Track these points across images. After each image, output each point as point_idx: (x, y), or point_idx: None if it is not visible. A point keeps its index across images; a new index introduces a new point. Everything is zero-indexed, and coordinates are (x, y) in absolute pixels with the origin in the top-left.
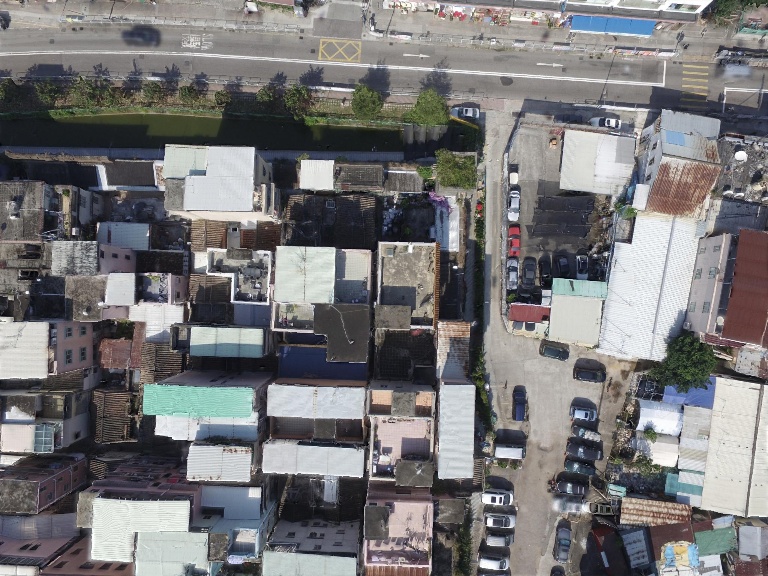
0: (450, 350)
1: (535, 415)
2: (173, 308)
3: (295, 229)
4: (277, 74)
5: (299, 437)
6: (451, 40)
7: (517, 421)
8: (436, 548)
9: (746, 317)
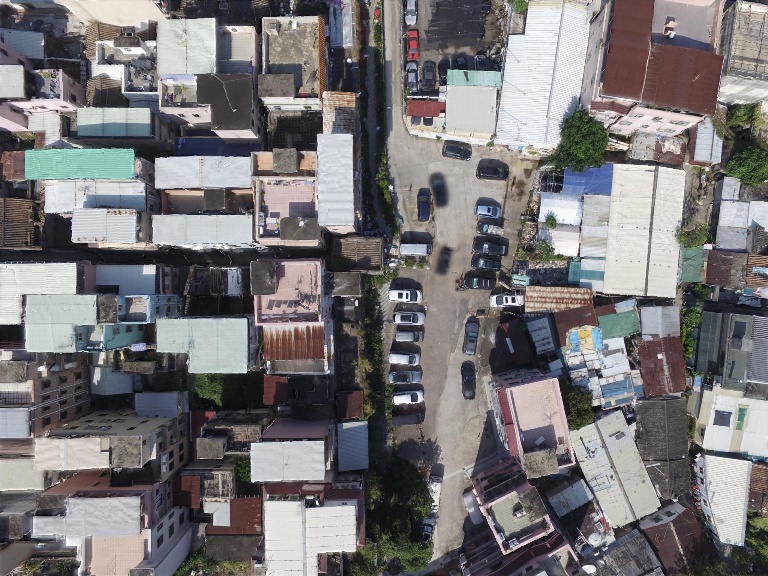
0: (336, 119)
1: (441, 216)
2: None
3: None
4: None
5: None
6: None
7: (423, 222)
8: (342, 339)
9: (625, 73)
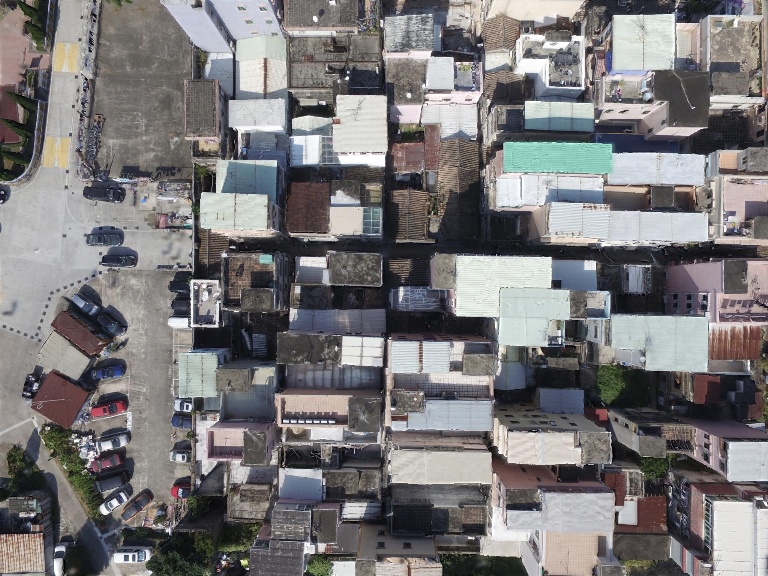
0: None
1: None
2: (468, 108)
3: (602, 18)
4: None
5: None
6: None
7: None
8: None
9: None
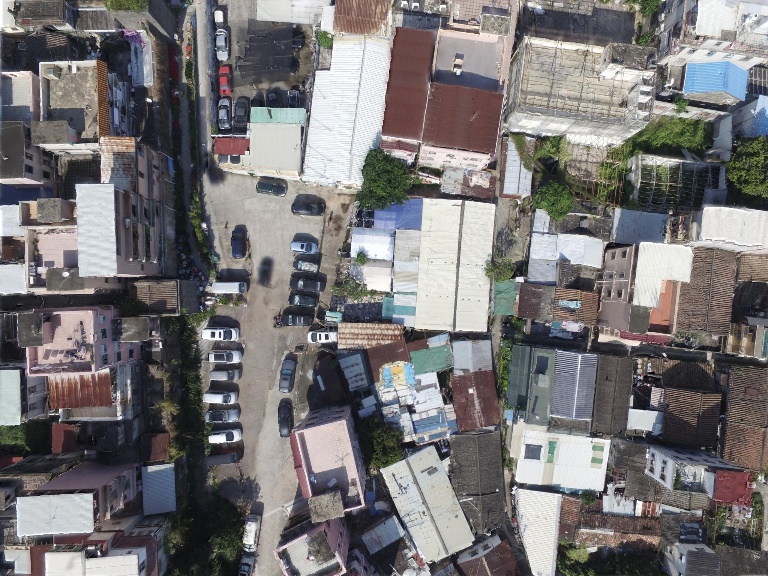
0: (114, 165)
1: (257, 253)
2: None
3: None
4: None
5: None
6: None
7: (239, 260)
8: (148, 381)
9: (404, 113)
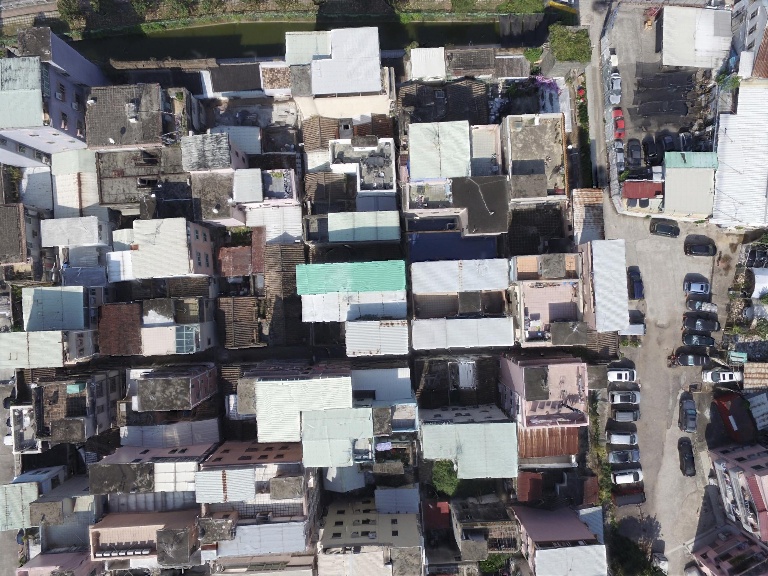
0: (586, 216)
1: (650, 294)
2: (291, 210)
3: (413, 116)
4: None
5: (442, 316)
6: None
7: (633, 301)
8: None
9: None
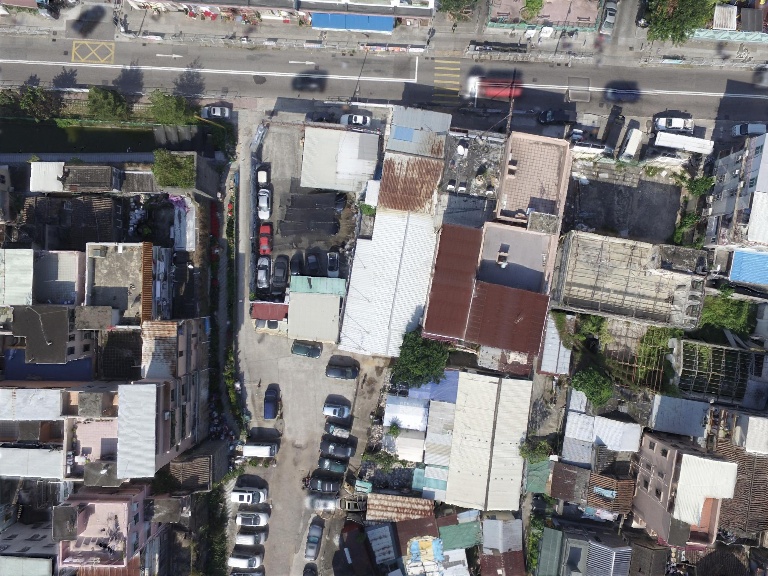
0: (155, 350)
1: (289, 413)
2: None
3: (20, 231)
4: (30, 77)
5: (11, 439)
6: (202, 40)
7: (271, 419)
8: (175, 547)
9: (448, 311)
